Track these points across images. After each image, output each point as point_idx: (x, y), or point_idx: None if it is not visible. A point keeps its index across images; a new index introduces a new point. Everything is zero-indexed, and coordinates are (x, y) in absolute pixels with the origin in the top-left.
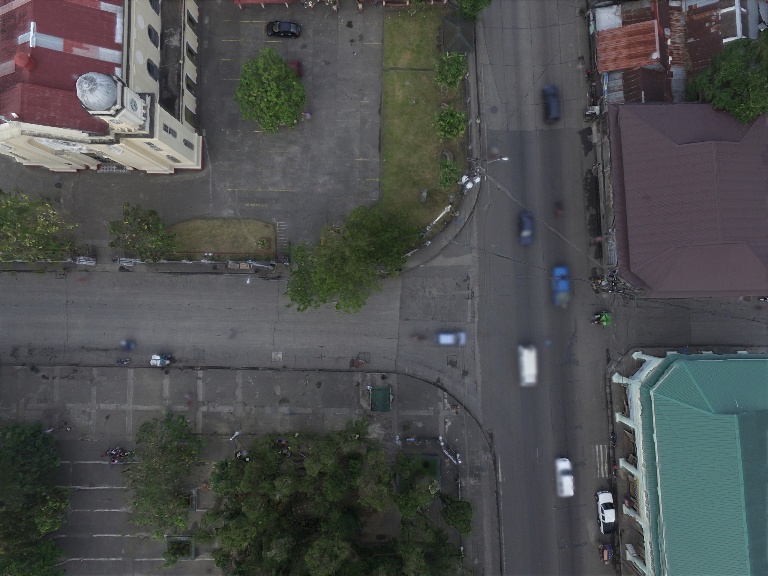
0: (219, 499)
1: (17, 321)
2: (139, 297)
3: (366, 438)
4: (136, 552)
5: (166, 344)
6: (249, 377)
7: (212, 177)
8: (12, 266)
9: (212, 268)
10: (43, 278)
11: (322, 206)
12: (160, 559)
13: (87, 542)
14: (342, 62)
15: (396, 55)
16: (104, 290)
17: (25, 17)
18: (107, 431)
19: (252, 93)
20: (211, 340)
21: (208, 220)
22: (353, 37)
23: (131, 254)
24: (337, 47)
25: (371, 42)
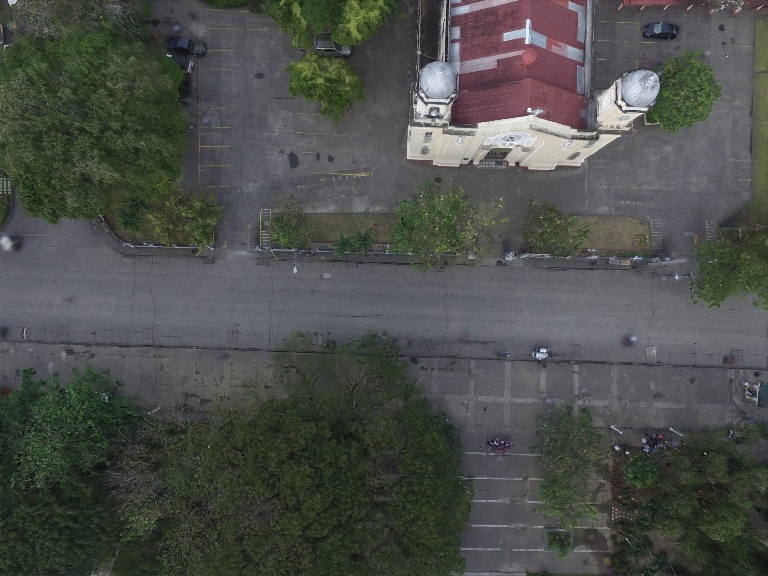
0: (595, 491)
1: (397, 313)
2: (517, 291)
3: (739, 434)
4: (513, 543)
5: (543, 338)
6: (624, 372)
7: (588, 174)
8: (393, 258)
9: (590, 264)
10: (422, 271)
11: (695, 205)
12: (536, 550)
13: (466, 532)
14: (714, 64)
15: (767, 58)
16: (482, 284)
17: (516, 14)
18: (485, 423)
19: (681, 93)
20: (587, 335)
21: (584, 217)
22: (725, 40)
23: (508, 249)
24: (710, 49)
25: (743, 45)
